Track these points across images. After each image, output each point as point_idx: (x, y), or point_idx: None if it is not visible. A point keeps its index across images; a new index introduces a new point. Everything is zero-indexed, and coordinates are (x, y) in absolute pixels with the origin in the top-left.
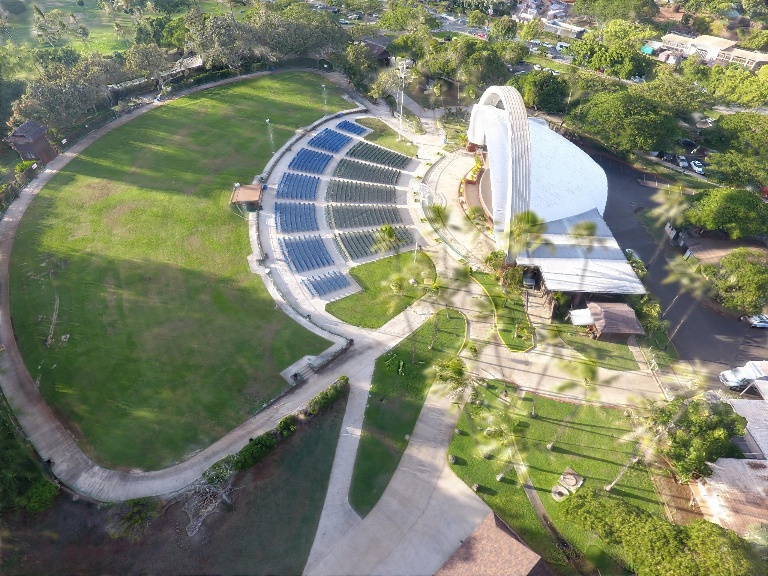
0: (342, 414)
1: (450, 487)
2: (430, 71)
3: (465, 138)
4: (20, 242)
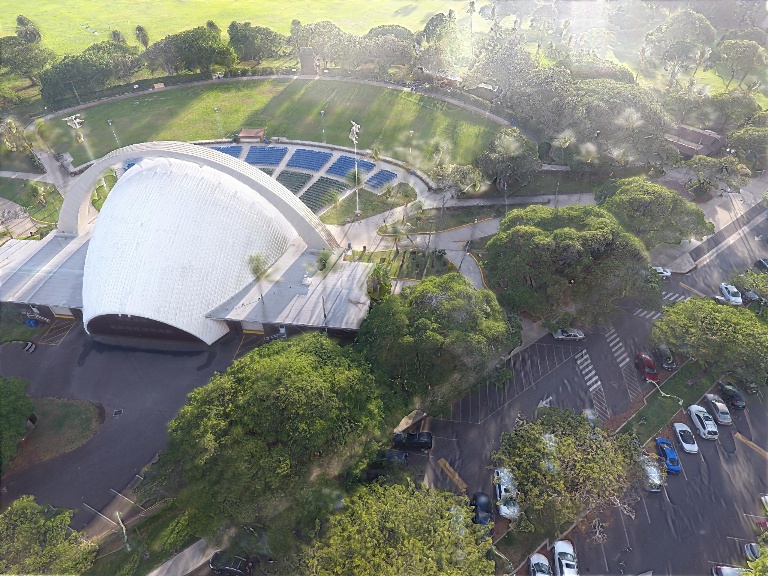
0: (28, 172)
1: None
2: None
3: None
4: (221, 83)
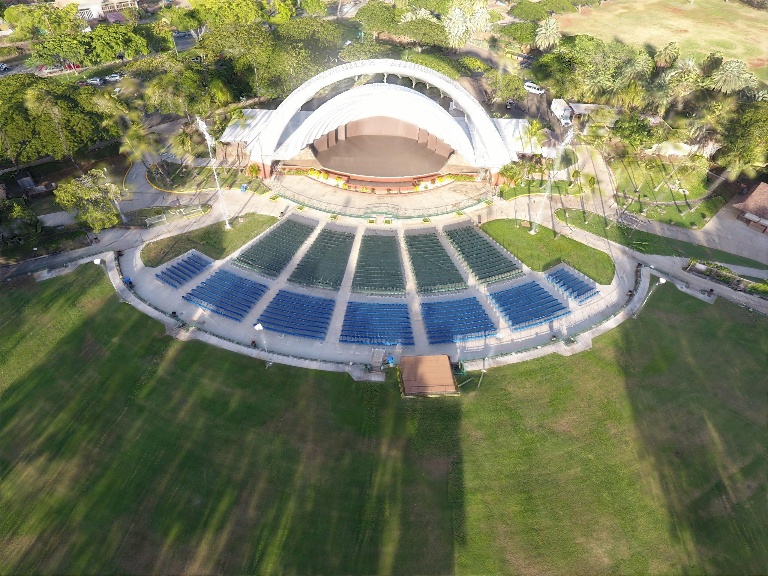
0: None
1: (714, 230)
2: (64, 155)
3: (257, 168)
4: None
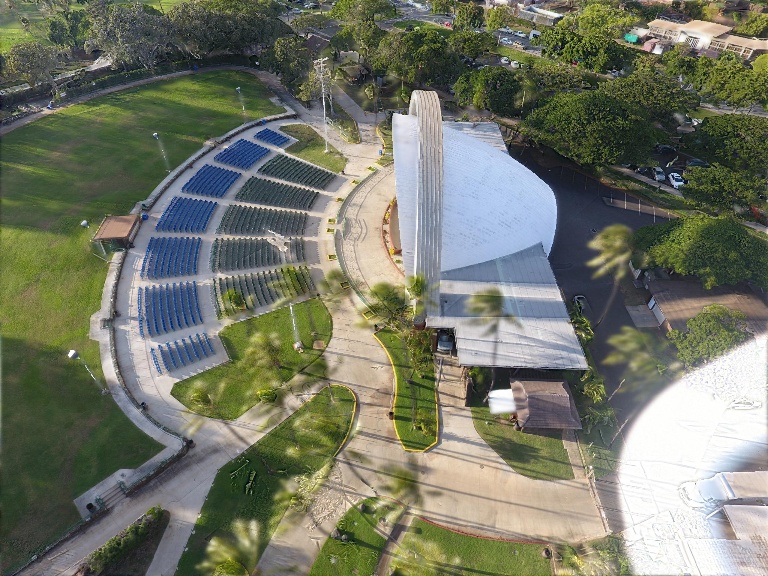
0: (146, 565)
1: None
2: (372, 68)
3: None
4: None
